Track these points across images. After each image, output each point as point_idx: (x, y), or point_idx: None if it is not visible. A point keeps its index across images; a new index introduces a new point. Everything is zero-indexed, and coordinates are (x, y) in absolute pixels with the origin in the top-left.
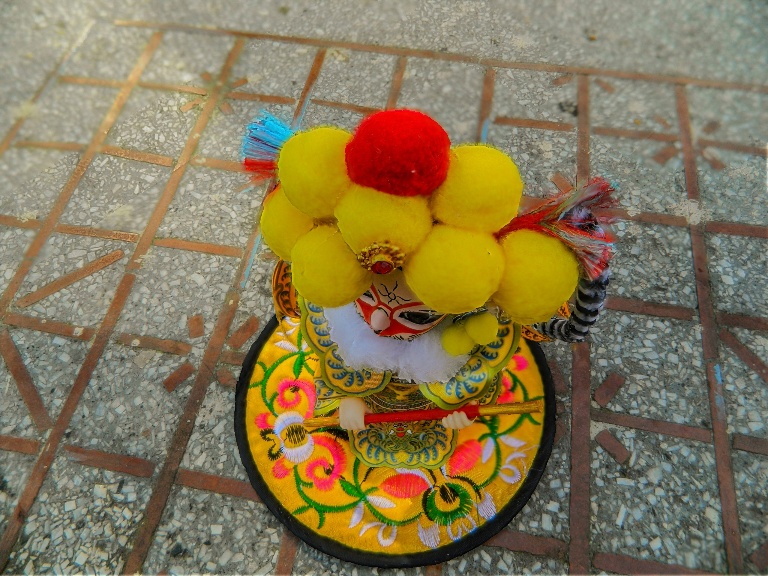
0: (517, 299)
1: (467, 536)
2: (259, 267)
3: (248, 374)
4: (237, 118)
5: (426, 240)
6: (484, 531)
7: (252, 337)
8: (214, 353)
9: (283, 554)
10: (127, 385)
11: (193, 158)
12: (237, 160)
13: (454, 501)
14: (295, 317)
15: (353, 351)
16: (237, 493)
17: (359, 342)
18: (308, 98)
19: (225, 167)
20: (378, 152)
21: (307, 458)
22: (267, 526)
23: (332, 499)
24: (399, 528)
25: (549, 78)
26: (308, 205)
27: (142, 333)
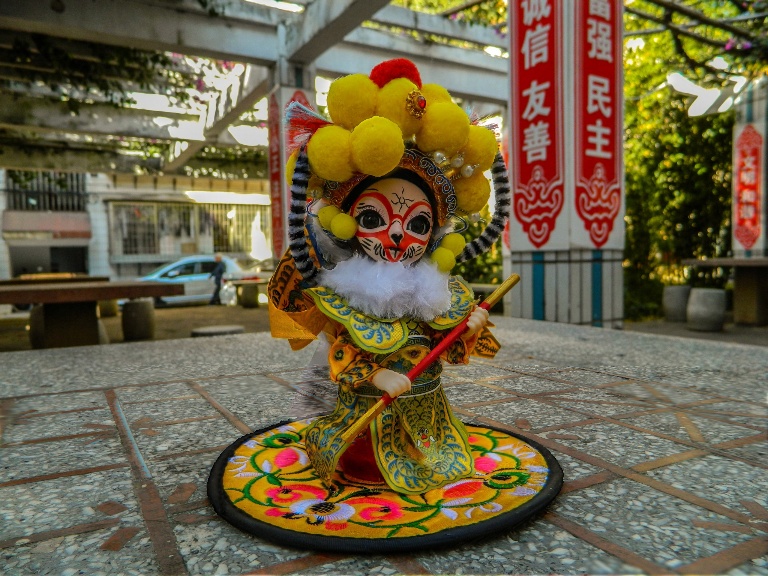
0: (480, 138)
1: (548, 480)
2: (157, 464)
3: (223, 496)
4: (43, 422)
5: (428, 106)
6: (554, 474)
7: (196, 492)
8: (156, 512)
9: (412, 574)
10: (37, 569)
11: (3, 445)
12: (65, 435)
13: (511, 477)
14: (303, 316)
15: (381, 281)
16: (301, 567)
17: (382, 273)
18: (118, 404)
19: (53, 440)
20: (395, 60)
21: (354, 512)
22: (368, 569)
23: (413, 517)
24: (494, 501)
25: (313, 370)
26: (362, 95)
27: (27, 534)
